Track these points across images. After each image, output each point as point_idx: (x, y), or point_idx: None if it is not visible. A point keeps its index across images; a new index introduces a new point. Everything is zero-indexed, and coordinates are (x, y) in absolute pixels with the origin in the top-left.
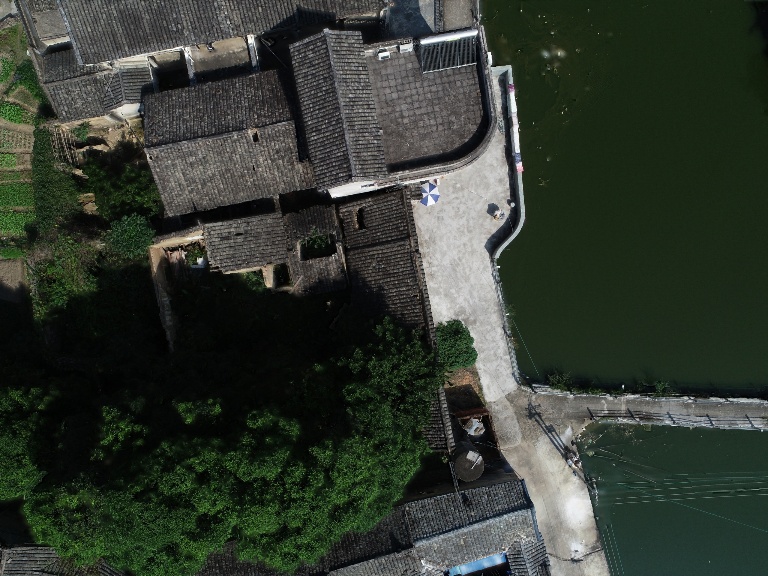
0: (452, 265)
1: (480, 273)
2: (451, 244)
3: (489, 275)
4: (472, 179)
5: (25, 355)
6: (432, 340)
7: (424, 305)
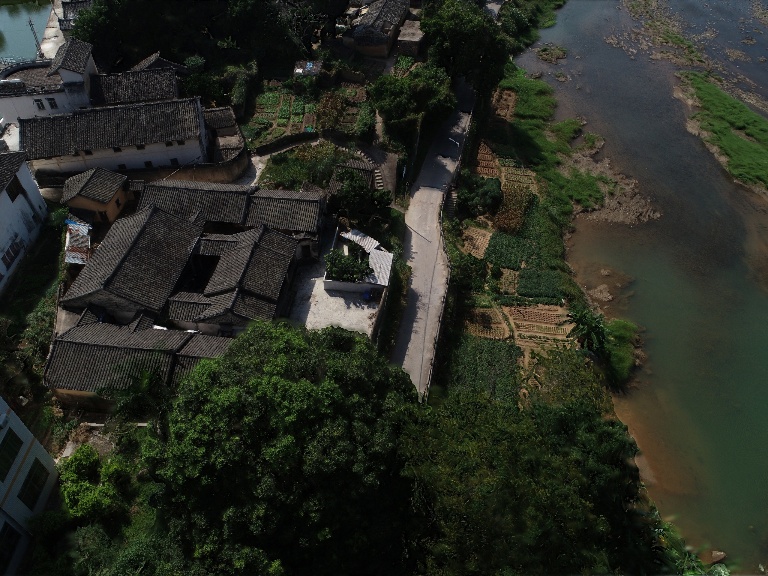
0: None
1: None
2: None
3: None
4: None
5: None
6: None
7: None
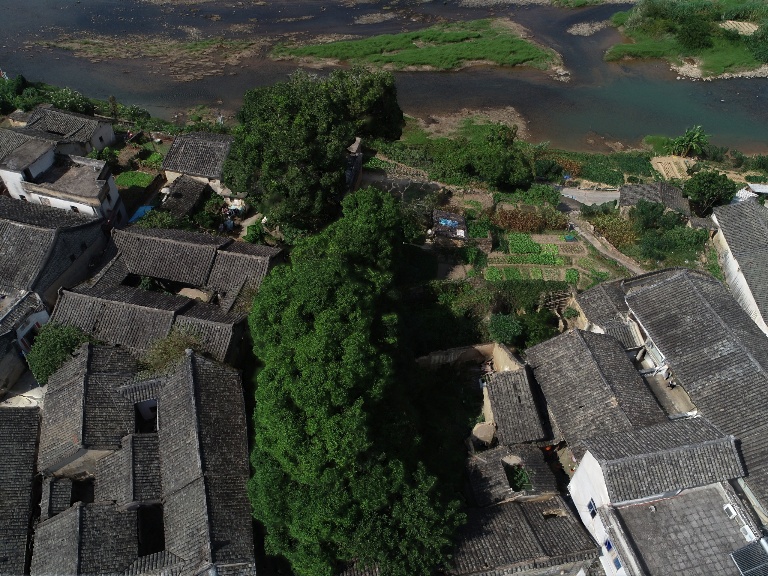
0: None
1: None
2: None
3: None
4: None
5: (404, 273)
6: None
7: (479, 571)
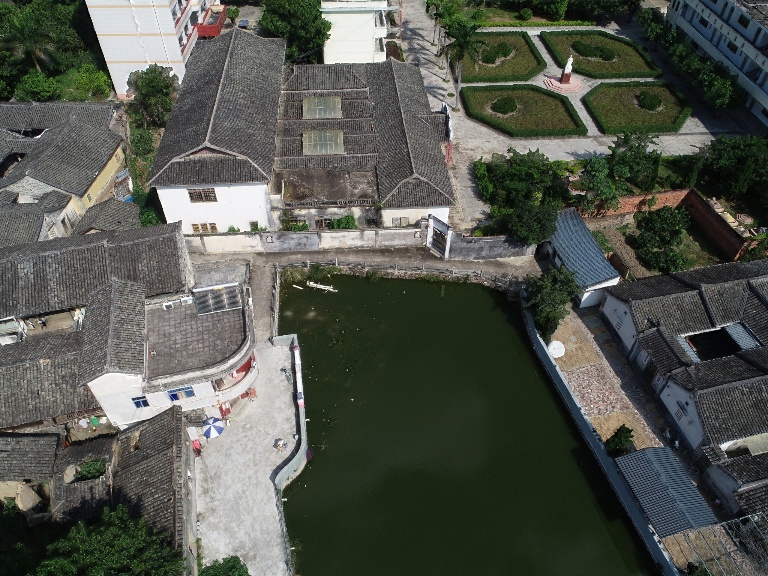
0: (235, 498)
1: (264, 504)
2: (236, 478)
3: (273, 506)
4: (261, 420)
5: None
6: (177, 543)
7: (174, 505)
